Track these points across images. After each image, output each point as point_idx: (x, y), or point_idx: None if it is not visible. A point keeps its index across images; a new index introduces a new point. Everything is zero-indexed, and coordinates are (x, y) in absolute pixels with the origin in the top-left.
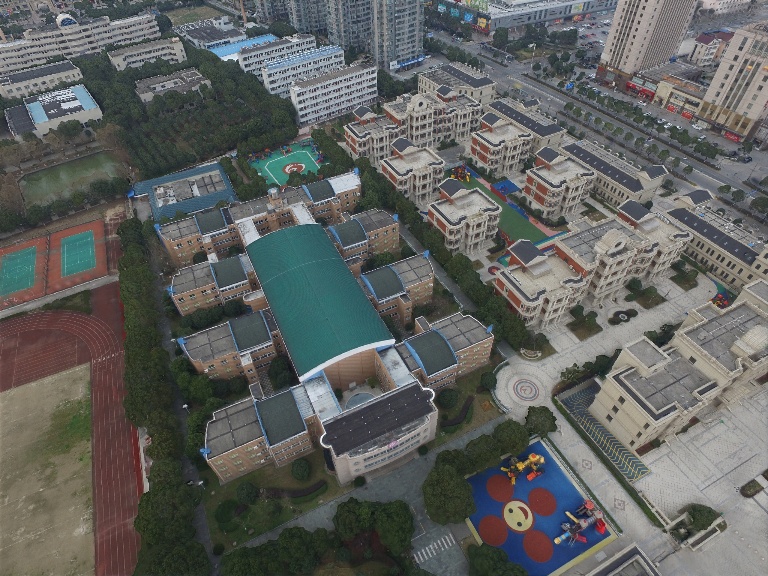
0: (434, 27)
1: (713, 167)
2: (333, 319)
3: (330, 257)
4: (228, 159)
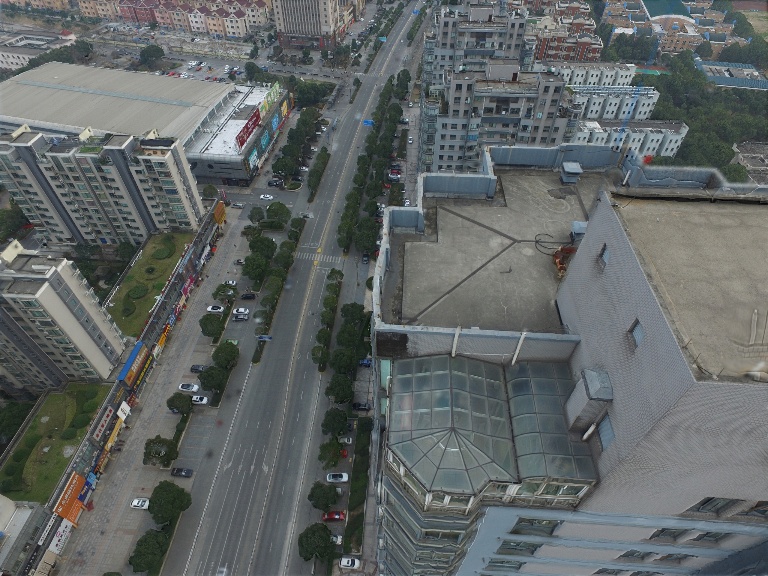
0: (306, 159)
1: None
2: None
3: (654, 8)
4: (700, 75)
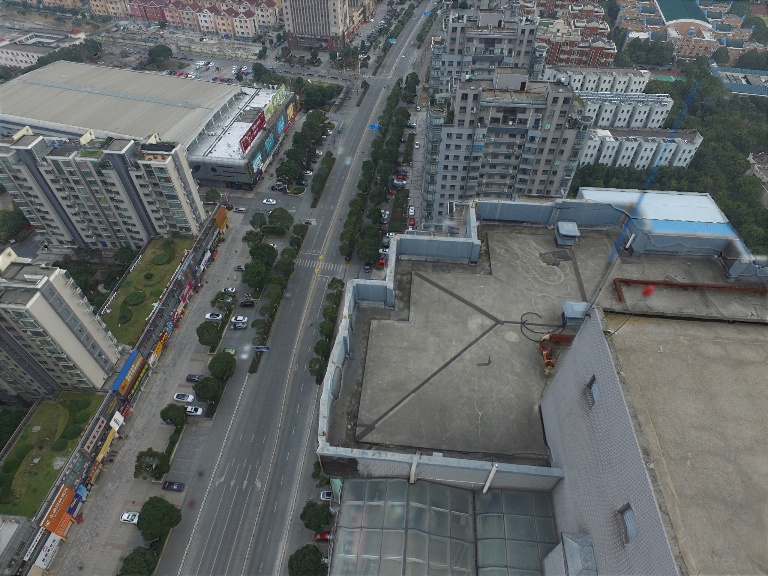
0: None
1: (414, 13)
2: (679, 0)
3: None
4: (716, 82)
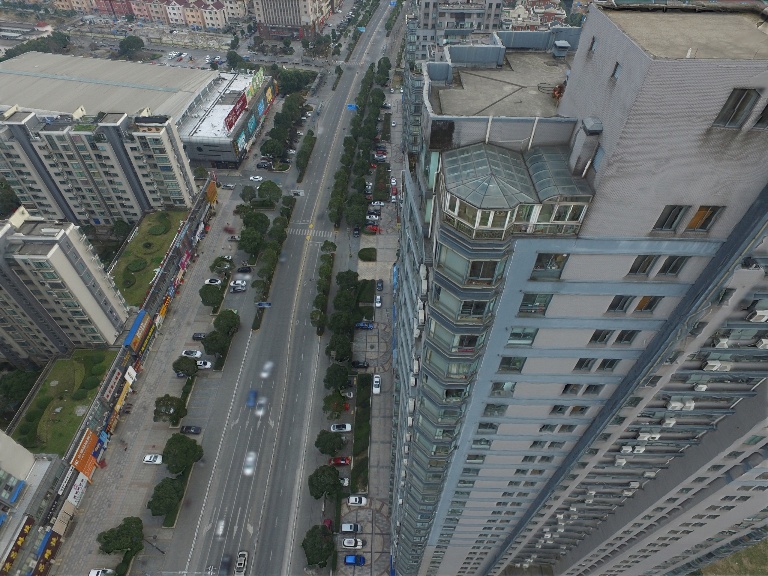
0: None
1: None
2: None
3: None
4: None
